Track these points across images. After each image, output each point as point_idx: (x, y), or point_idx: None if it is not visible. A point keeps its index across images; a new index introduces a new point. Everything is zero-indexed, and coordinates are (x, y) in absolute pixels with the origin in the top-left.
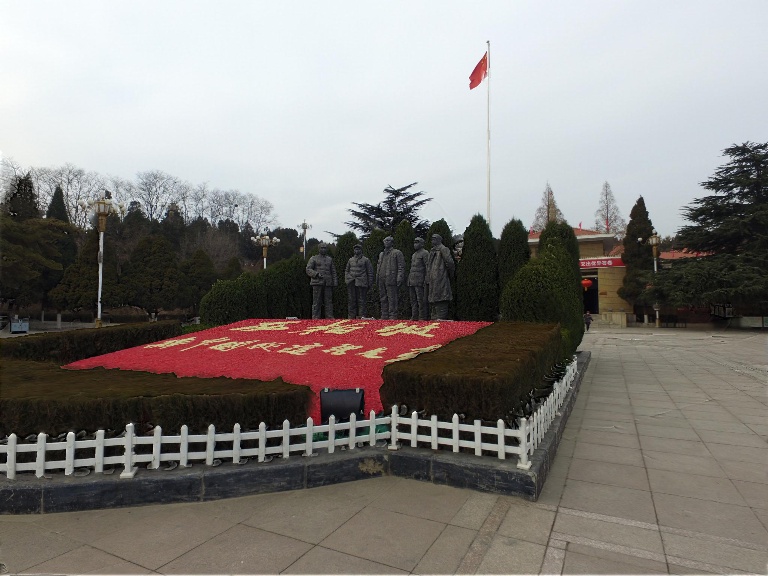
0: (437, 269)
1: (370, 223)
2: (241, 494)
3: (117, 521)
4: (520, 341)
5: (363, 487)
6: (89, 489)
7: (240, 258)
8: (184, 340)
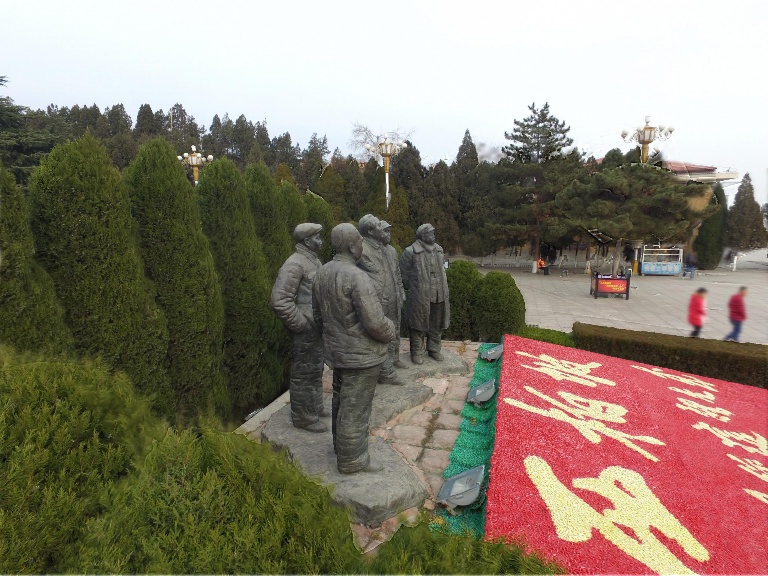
0: None
1: None
2: None
3: None
4: None
5: None
6: None
7: None
8: None
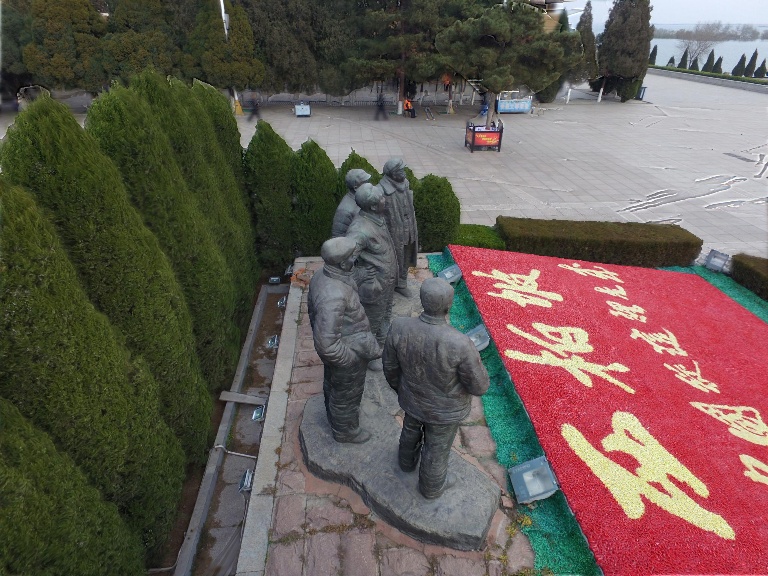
0: None
1: None
2: None
3: None
4: (593, 224)
5: None
6: None
7: None
8: None
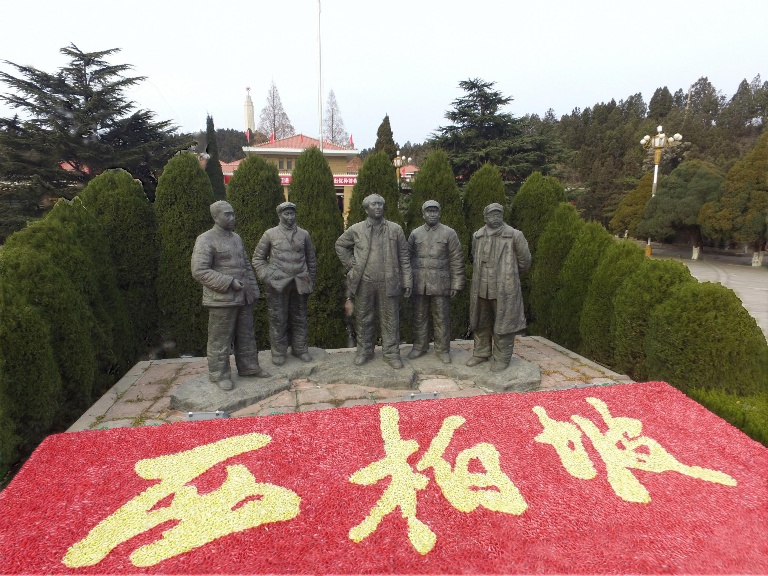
0: (513, 274)
1: (47, 101)
2: None
3: None
4: None
5: None
6: None
7: None
8: None
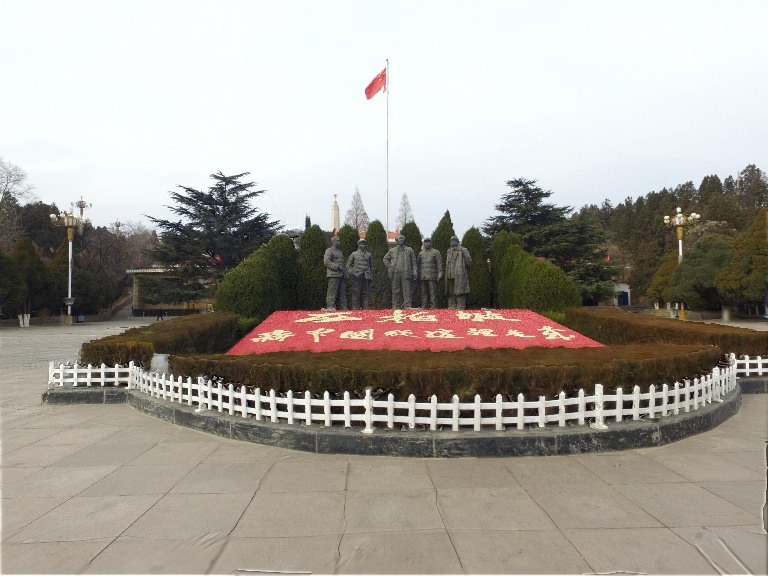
0: (461, 266)
1: (201, 210)
2: (738, 408)
3: (751, 424)
4: (659, 318)
5: (755, 399)
6: (719, 411)
7: (34, 240)
8: (279, 333)
